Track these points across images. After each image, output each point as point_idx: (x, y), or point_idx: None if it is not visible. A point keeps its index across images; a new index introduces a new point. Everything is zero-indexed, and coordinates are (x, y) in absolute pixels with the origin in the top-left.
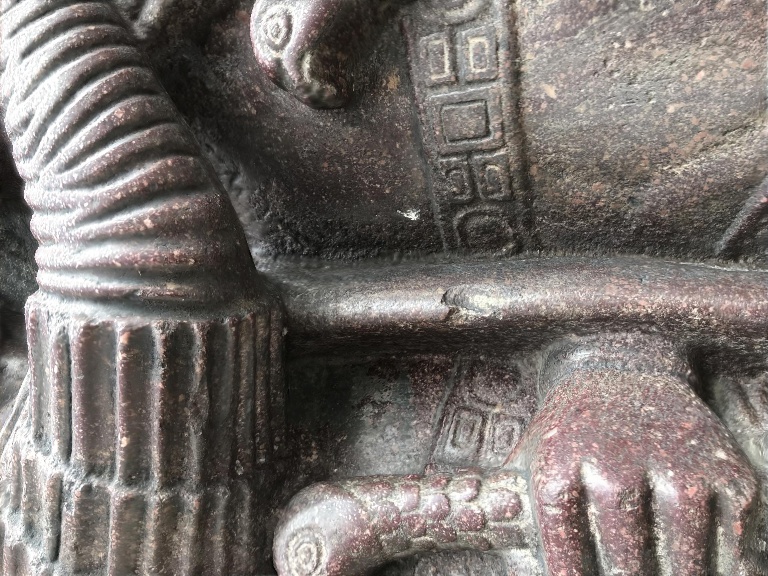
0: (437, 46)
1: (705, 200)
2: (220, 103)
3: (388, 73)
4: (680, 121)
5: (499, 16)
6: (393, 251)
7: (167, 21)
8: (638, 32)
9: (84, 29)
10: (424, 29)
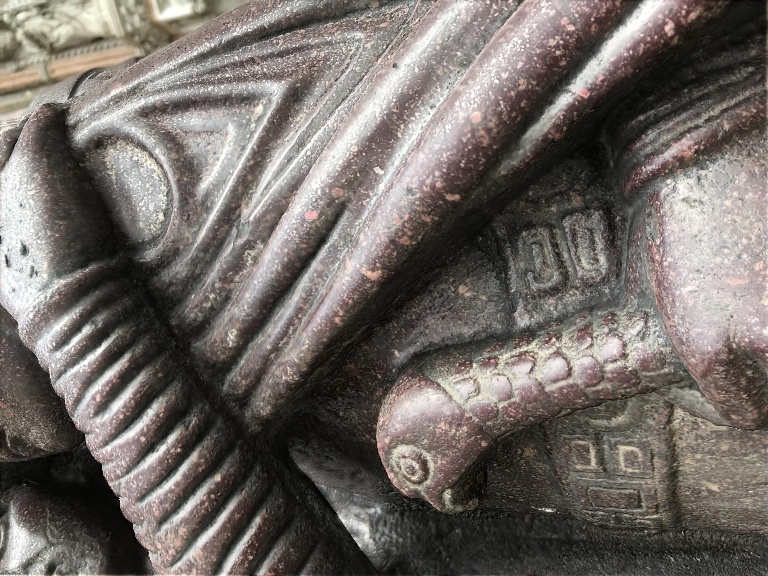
0: (582, 447)
1: None
2: (336, 432)
3: (523, 445)
4: None
5: (654, 434)
6: (524, 514)
7: (279, 410)
8: None
9: (212, 484)
10: (565, 427)
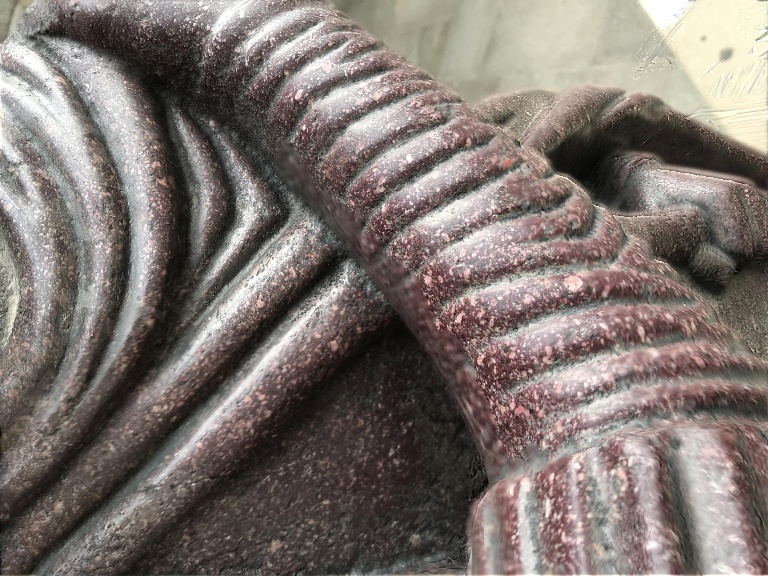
0: None
1: None
2: None
3: None
4: None
5: None
6: None
7: None
8: (760, 344)
9: None
10: None
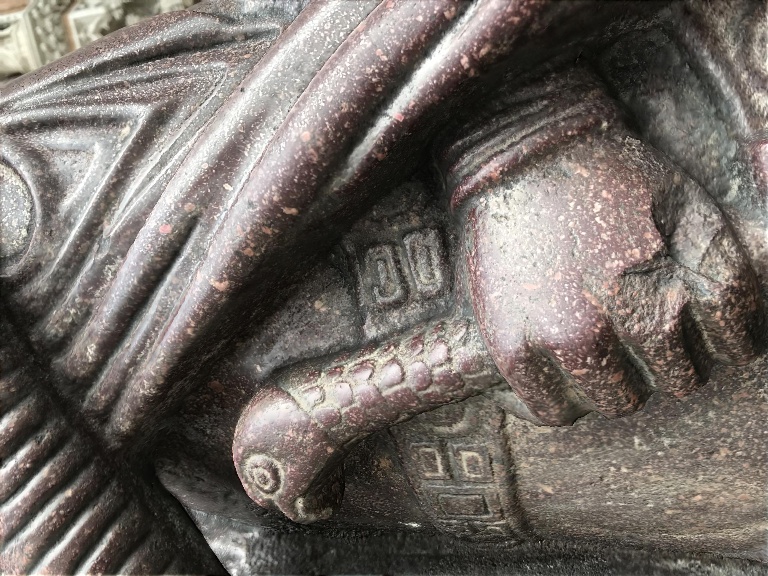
0: (428, 454)
1: (702, 550)
2: (204, 451)
3: (379, 456)
4: (678, 519)
5: (490, 439)
6: (396, 532)
7: (140, 426)
8: (633, 463)
9: (61, 500)
10: (413, 436)
